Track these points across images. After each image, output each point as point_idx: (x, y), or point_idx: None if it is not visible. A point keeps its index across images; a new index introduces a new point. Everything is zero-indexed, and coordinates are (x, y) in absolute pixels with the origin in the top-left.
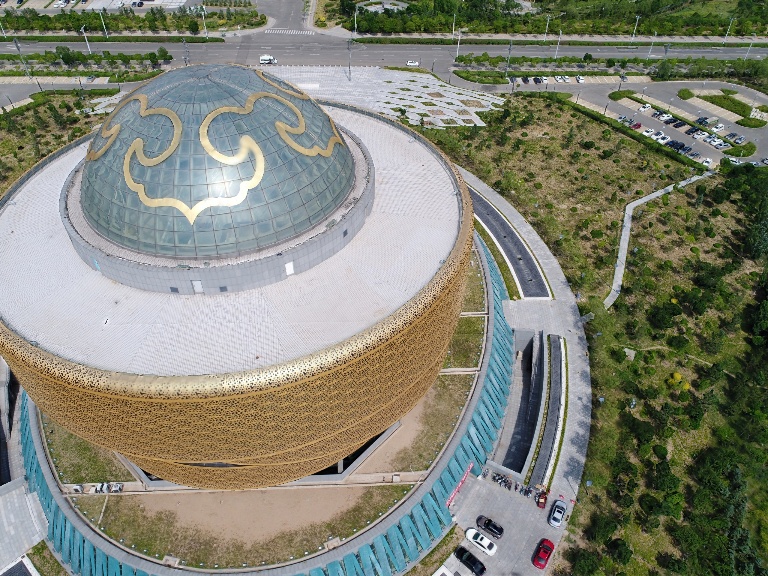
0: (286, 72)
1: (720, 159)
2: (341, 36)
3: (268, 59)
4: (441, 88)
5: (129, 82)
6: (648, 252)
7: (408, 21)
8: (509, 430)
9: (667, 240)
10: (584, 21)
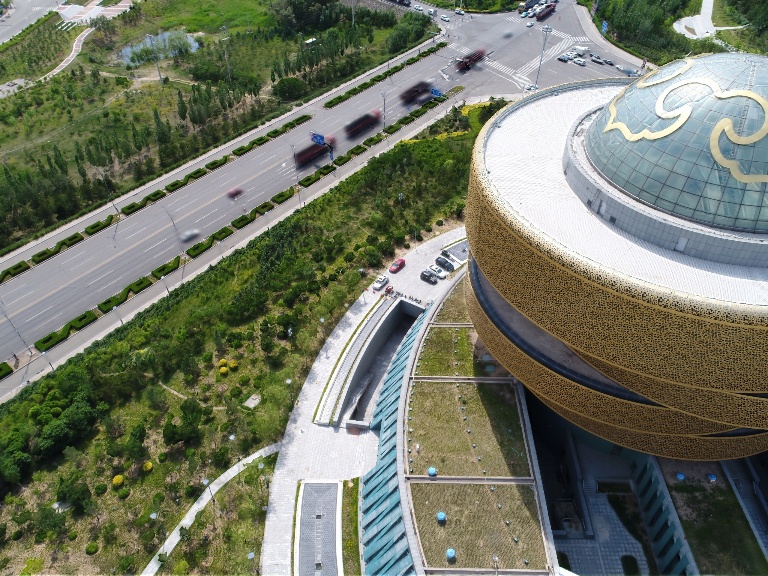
0: None
1: None
2: None
3: None
4: None
5: None
6: None
7: None
8: None
9: None
10: None
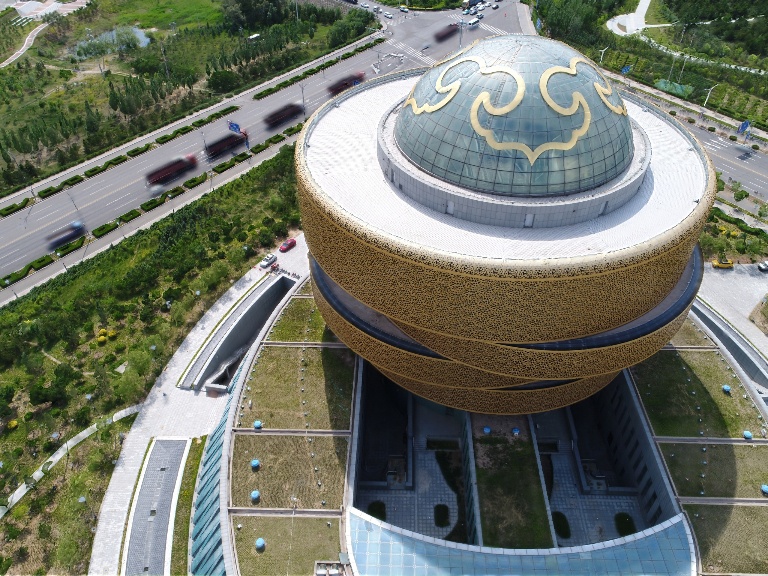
0: None
1: None
2: None
3: None
4: None
5: None
6: None
7: None
8: None
9: None
10: None
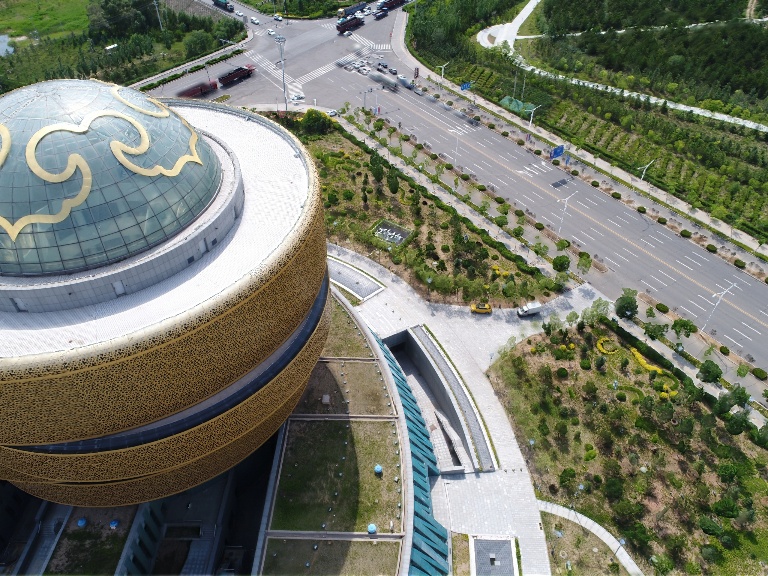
0: None
1: None
2: None
3: None
4: None
5: None
6: None
7: None
8: None
9: None
10: None
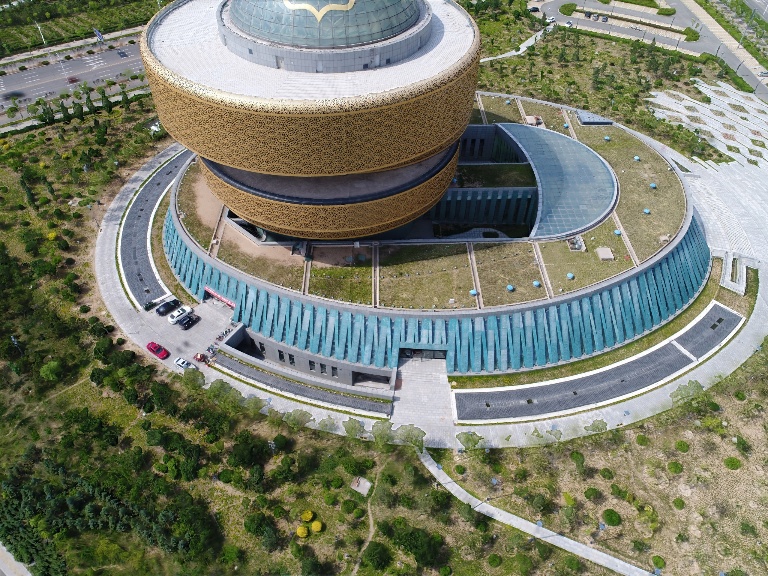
0: None
1: None
2: None
3: None
4: None
5: None
6: None
7: None
8: None
9: None
10: None
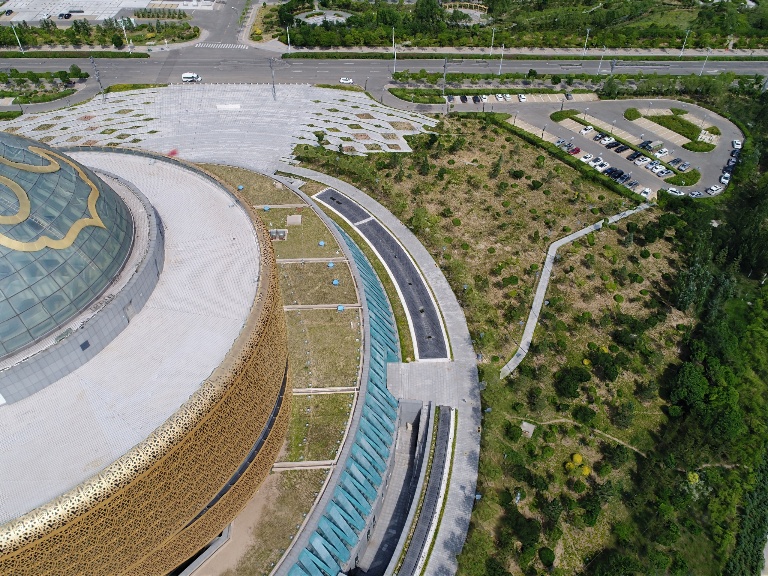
0: (209, 91)
1: (658, 190)
2: (276, 50)
3: (191, 77)
4: (372, 108)
5: (35, 103)
6: (566, 301)
7: (347, 34)
8: (384, 523)
9: (589, 286)
10: (535, 33)
